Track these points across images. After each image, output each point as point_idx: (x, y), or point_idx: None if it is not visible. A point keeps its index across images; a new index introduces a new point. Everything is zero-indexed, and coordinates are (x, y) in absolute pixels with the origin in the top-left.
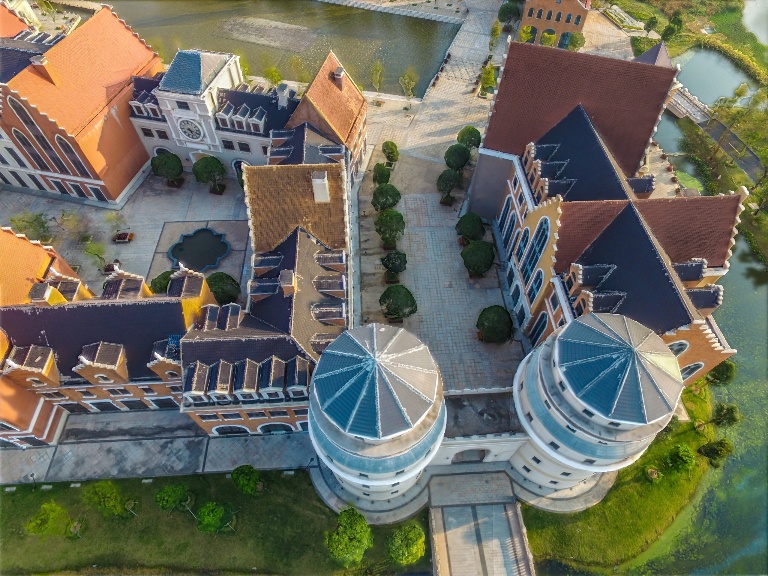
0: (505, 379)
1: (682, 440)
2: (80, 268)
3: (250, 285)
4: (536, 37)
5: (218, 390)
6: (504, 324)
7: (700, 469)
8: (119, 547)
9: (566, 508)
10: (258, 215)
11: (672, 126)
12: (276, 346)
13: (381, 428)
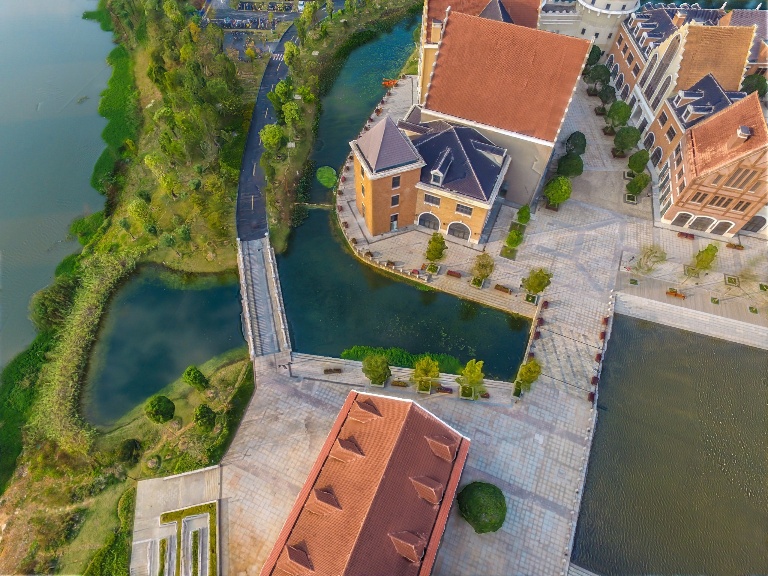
0: None
1: None
2: None
3: None
4: None
5: (685, 4)
6: None
7: None
8: None
9: None
10: None
11: (293, 244)
12: None
13: None
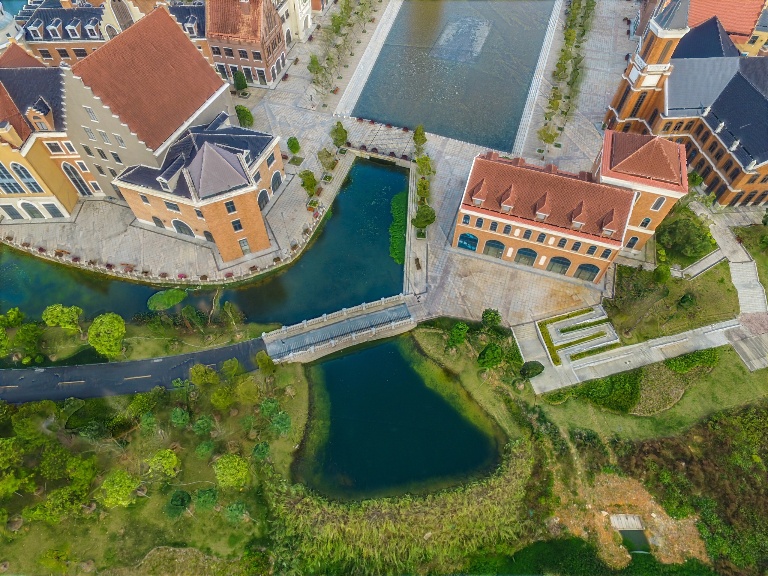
0: None
1: None
2: (191, 3)
3: (86, 3)
4: None
5: (30, 1)
6: None
7: None
8: None
9: None
10: None
11: (272, 317)
12: None
13: None
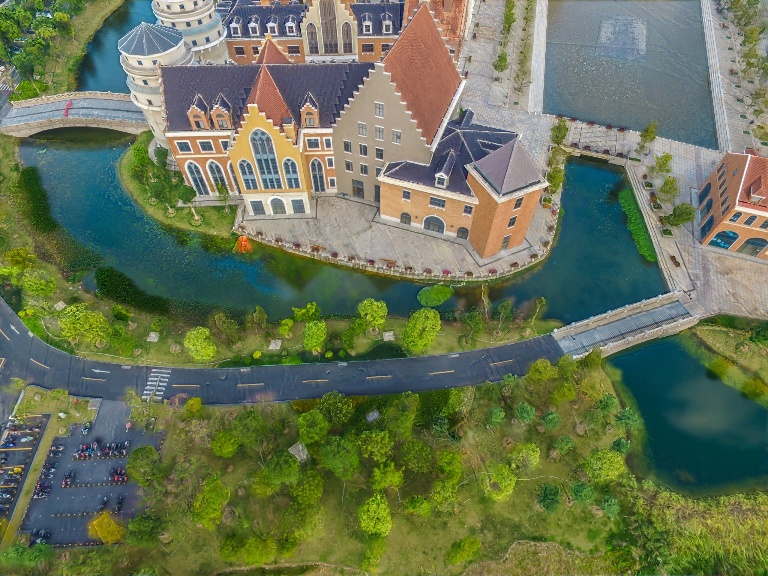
0: None
1: (166, 200)
2: None
3: None
4: (704, 200)
5: None
6: None
7: (148, 208)
8: None
9: (152, 144)
10: None
11: (547, 313)
12: None
13: None
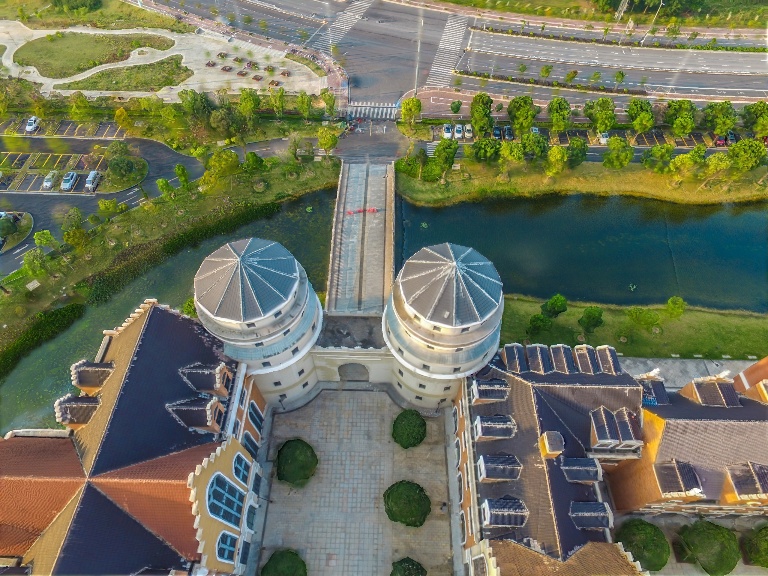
0: (300, 417)
1: None
2: None
3: (598, 468)
4: None
5: (584, 347)
6: (291, 444)
7: None
8: (616, 318)
9: None
10: (631, 575)
11: None
12: (544, 380)
13: (447, 245)
